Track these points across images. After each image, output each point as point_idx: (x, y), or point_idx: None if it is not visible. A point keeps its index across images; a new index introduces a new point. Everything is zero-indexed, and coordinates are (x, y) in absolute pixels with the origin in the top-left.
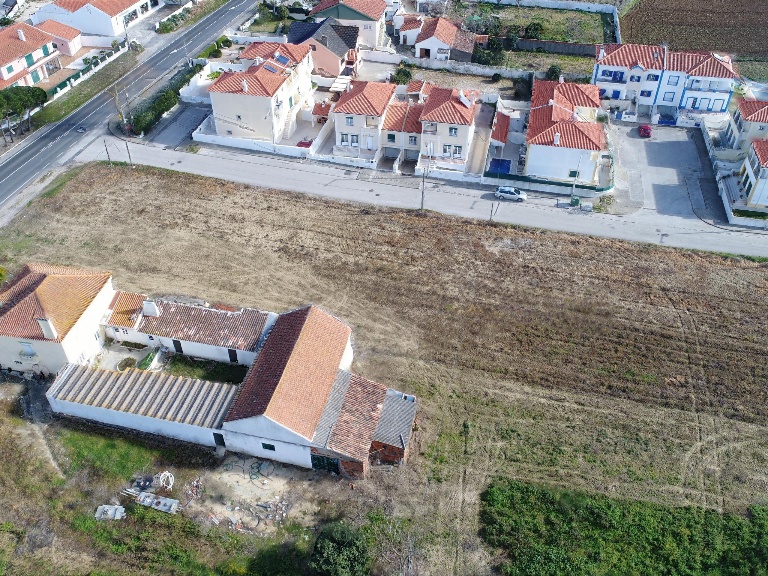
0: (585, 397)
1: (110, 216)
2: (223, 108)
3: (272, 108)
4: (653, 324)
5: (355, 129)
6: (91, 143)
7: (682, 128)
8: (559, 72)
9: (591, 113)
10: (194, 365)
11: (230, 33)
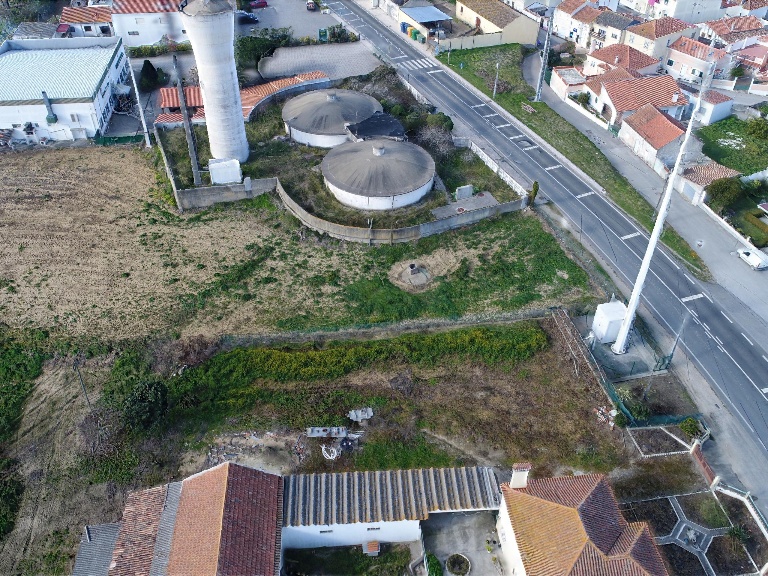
0: None
1: None
2: None
3: None
4: None
5: None
6: None
7: None
8: None
9: None
10: None
11: None
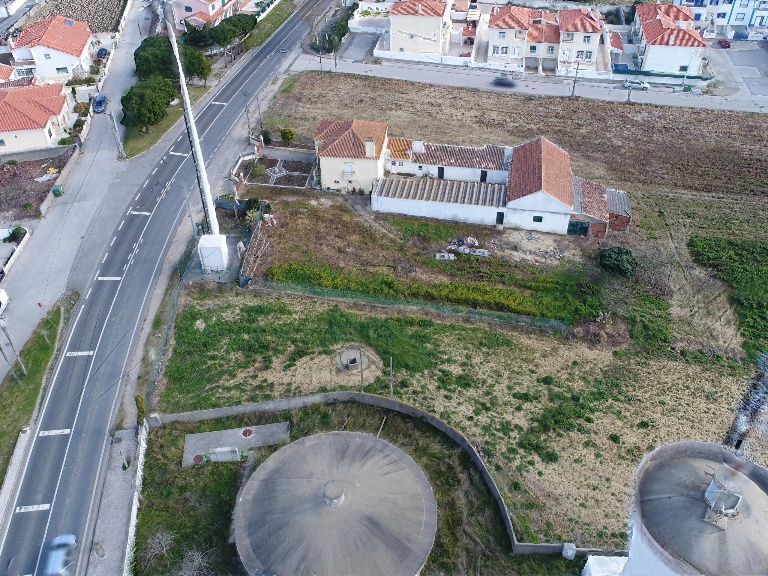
0: (737, 196)
1: (340, 104)
2: (400, 28)
3: (440, 27)
4: None
5: (506, 42)
6: (296, 59)
7: (753, 41)
8: None
9: (687, 26)
10: None
11: None
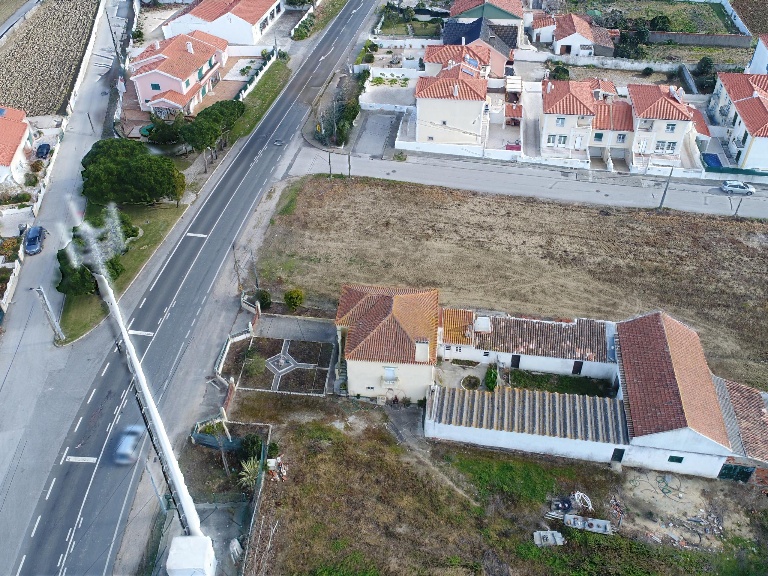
0: None
1: (359, 230)
2: (429, 114)
3: (482, 112)
4: None
5: (565, 130)
6: (296, 156)
7: None
8: (711, 64)
9: None
10: (537, 380)
11: (369, 37)
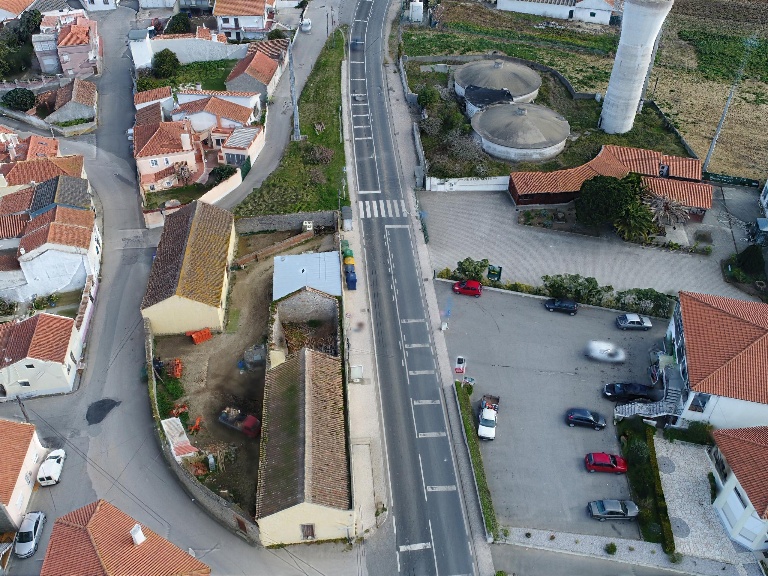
0: None
1: None
2: None
3: None
4: (741, 5)
5: None
6: None
7: None
8: None
9: None
10: None
11: None
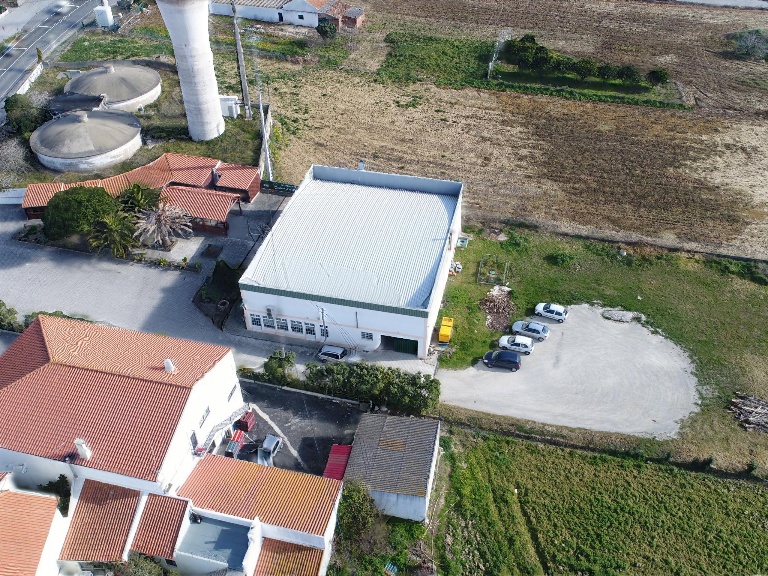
0: (441, 20)
1: None
2: None
3: None
4: (484, 6)
5: None
6: None
7: None
8: None
9: None
10: None
11: None
